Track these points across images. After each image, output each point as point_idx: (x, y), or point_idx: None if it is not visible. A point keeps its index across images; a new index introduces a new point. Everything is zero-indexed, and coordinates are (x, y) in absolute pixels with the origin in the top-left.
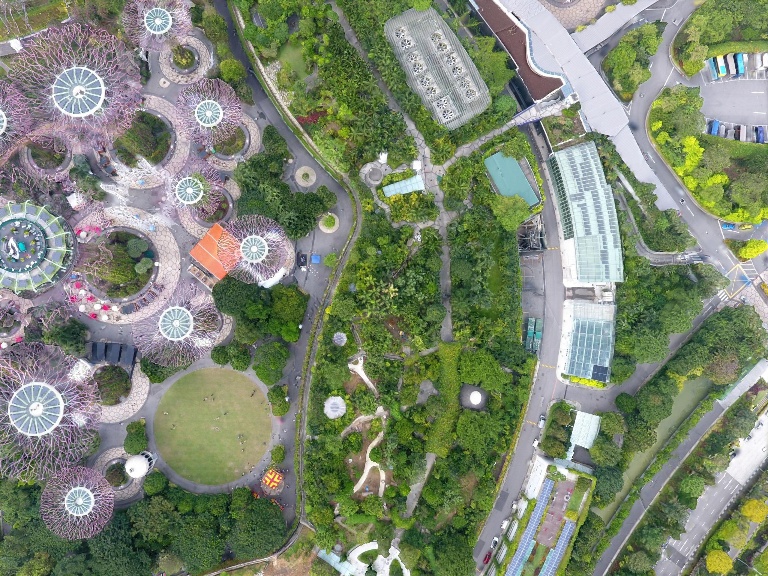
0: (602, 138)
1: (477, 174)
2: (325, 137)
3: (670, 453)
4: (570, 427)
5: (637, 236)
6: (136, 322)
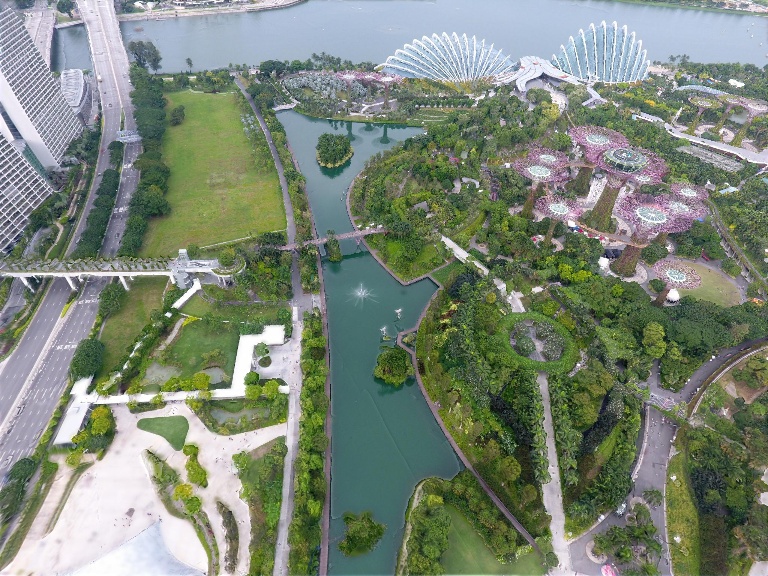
0: None
1: None
2: None
3: None
4: None
5: None
6: None
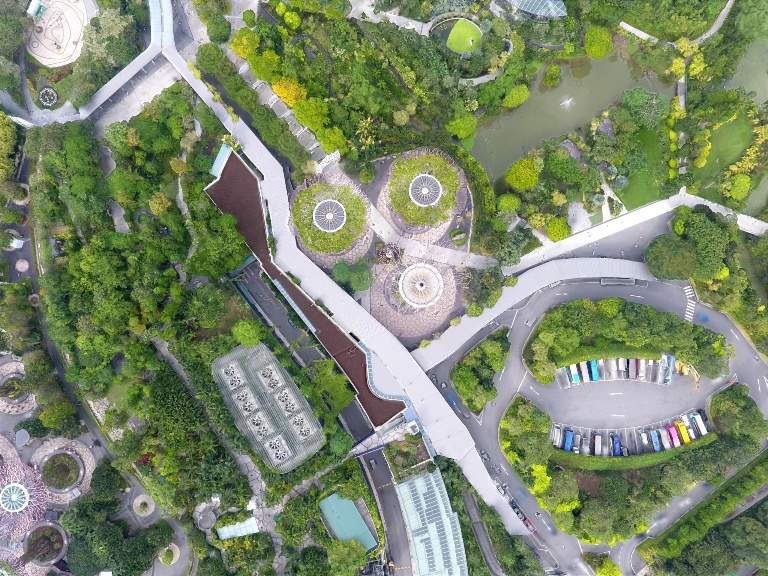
0: (448, 461)
1: (312, 518)
2: (155, 479)
3: None
4: None
5: (484, 568)
6: None
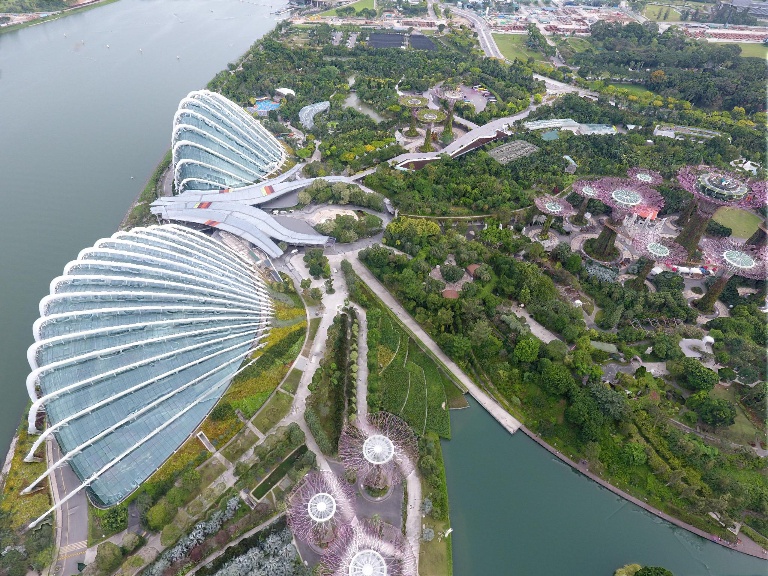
0: None
1: None
2: None
3: None
4: None
5: (551, 115)
6: None
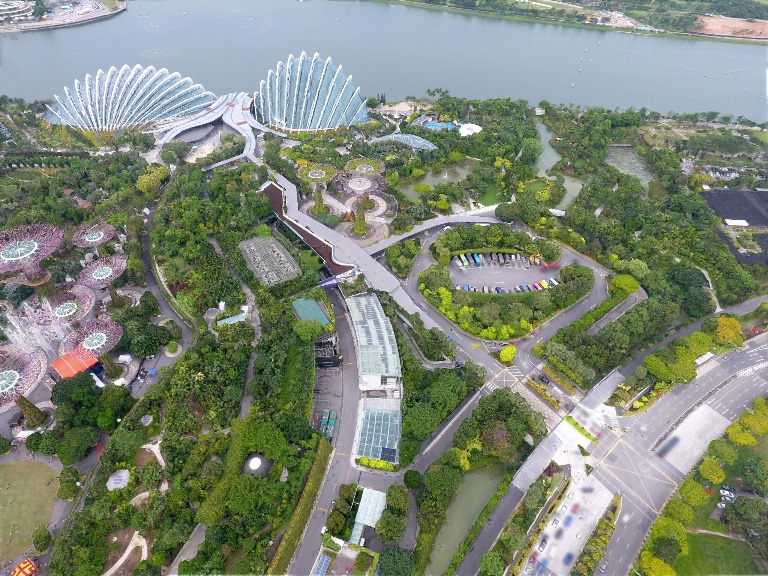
0: None
1: (285, 309)
2: None
3: (473, 541)
4: (357, 505)
5: (410, 345)
6: None
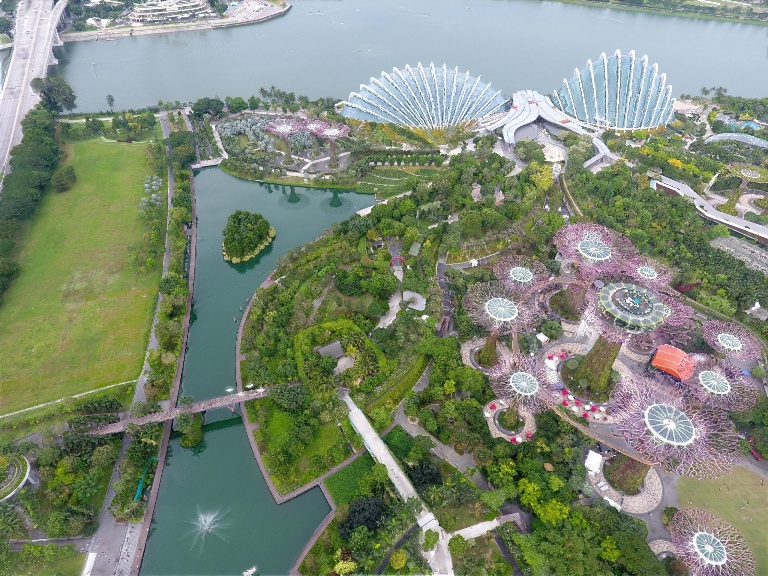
0: None
1: None
2: None
3: None
4: None
5: None
6: (684, 380)
